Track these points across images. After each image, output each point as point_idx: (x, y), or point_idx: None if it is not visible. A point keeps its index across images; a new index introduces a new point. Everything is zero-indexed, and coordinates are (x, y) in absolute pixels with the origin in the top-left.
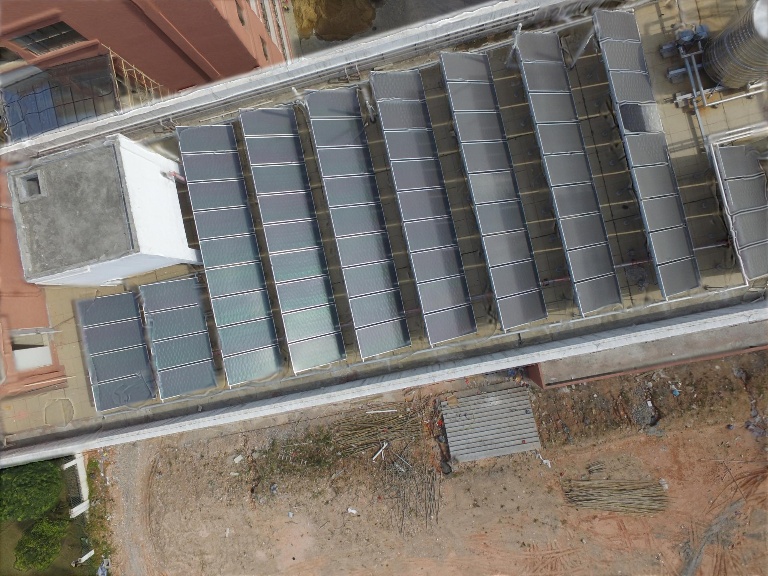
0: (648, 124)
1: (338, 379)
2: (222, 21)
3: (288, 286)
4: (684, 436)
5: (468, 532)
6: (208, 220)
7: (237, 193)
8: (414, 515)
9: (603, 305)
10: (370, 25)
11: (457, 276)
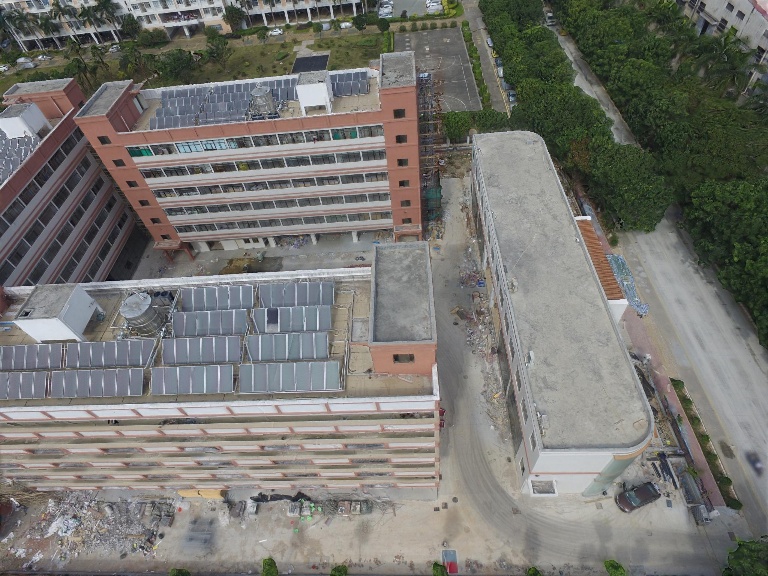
0: None
1: None
2: None
3: None
4: None
5: None
6: (15, 142)
7: None
8: None
9: None
10: None
11: None
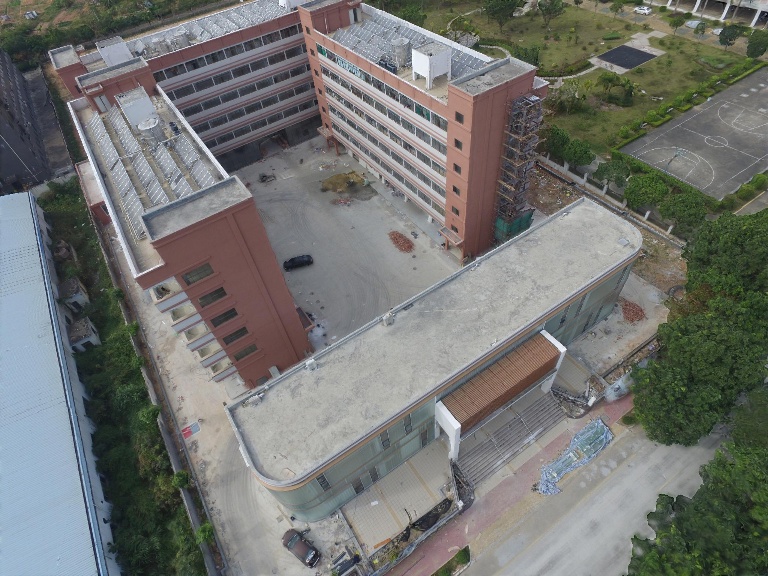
0: None
1: (248, 5)
2: None
3: (260, 8)
4: None
5: None
6: None
7: None
8: None
9: (204, 22)
10: None
11: None
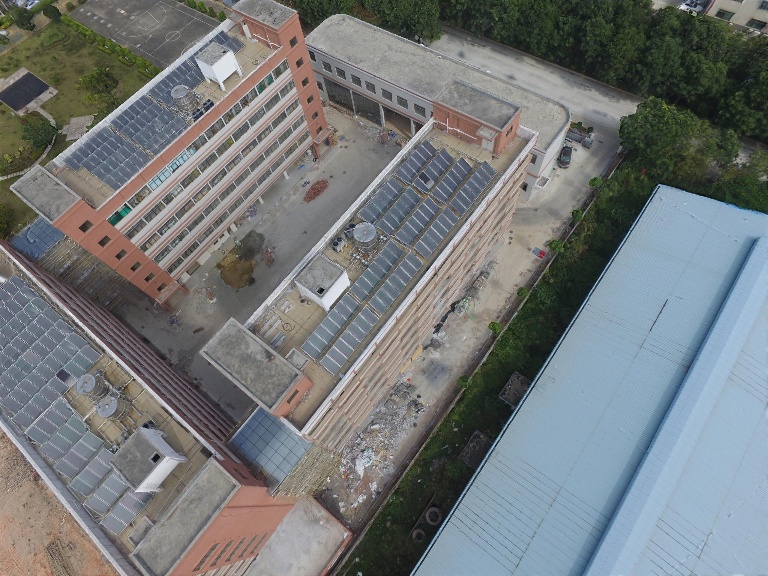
0: (68, 381)
1: None
2: (94, 255)
3: None
4: (110, 575)
5: (8, 513)
6: None
7: None
8: (5, 481)
9: (7, 407)
10: (238, 288)
11: (6, 368)
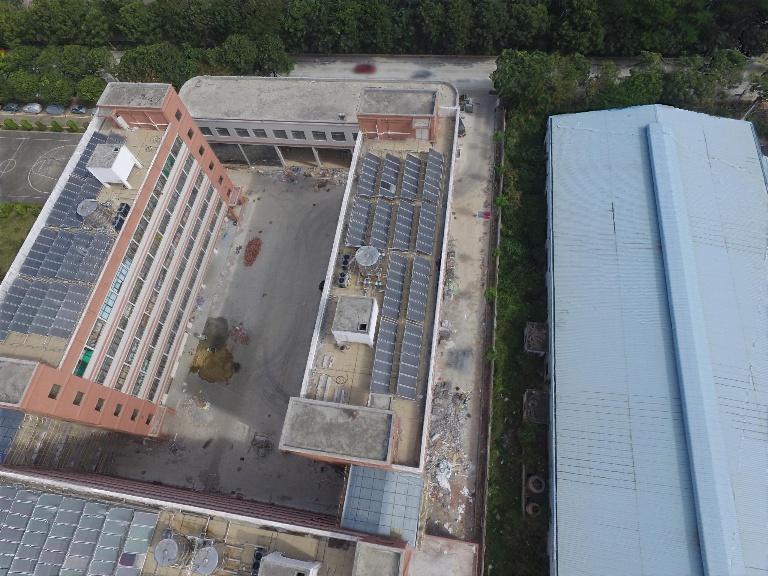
0: (136, 562)
1: None
2: None
3: None
4: None
5: None
6: None
7: (4, 517)
8: None
9: None
10: (227, 380)
11: None
